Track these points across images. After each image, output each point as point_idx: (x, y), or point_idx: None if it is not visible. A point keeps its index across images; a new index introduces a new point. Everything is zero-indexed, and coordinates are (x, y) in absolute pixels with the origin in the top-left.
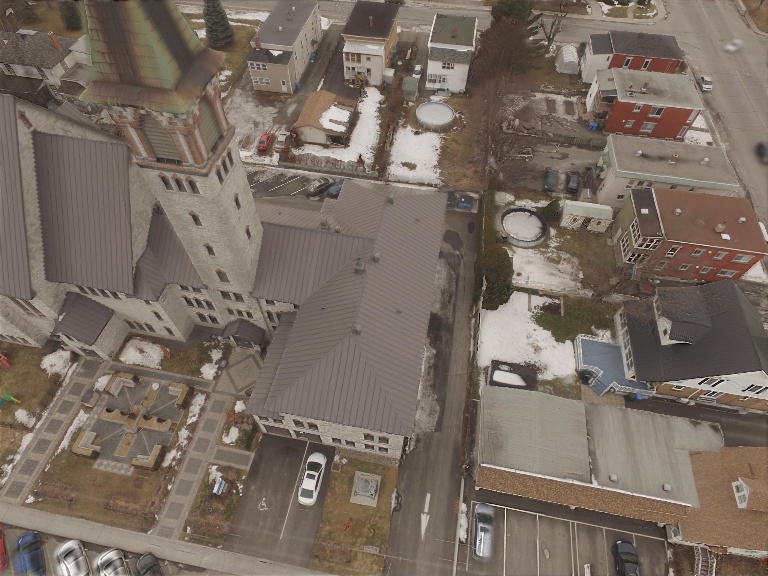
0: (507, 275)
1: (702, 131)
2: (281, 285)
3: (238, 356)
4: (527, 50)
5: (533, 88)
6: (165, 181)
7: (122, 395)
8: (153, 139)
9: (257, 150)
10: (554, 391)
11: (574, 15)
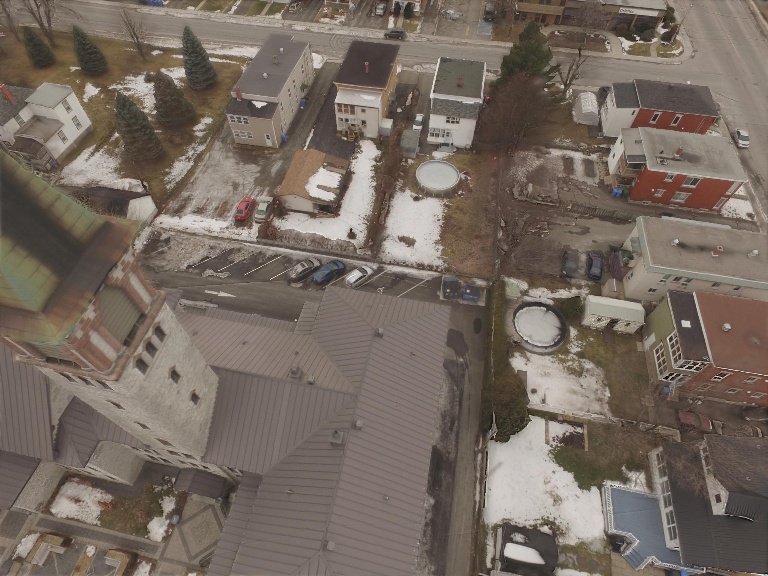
0: (521, 408)
1: (741, 199)
2: (240, 449)
3: (194, 507)
4: (542, 103)
5: (548, 144)
6: (65, 376)
7: (48, 564)
8: (35, 342)
9: (234, 220)
10: (578, 562)
11: (592, 52)
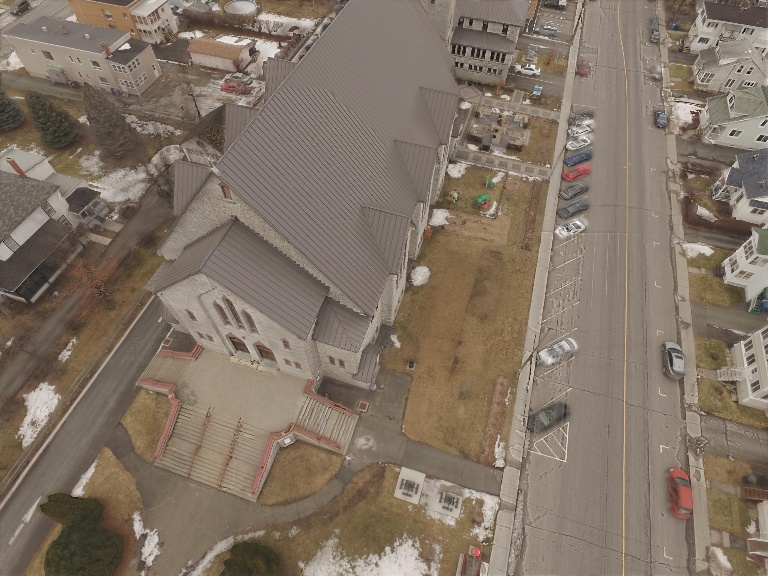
0: None
1: None
2: None
3: None
4: None
5: None
6: None
7: None
8: None
9: (242, 95)
10: None
11: None
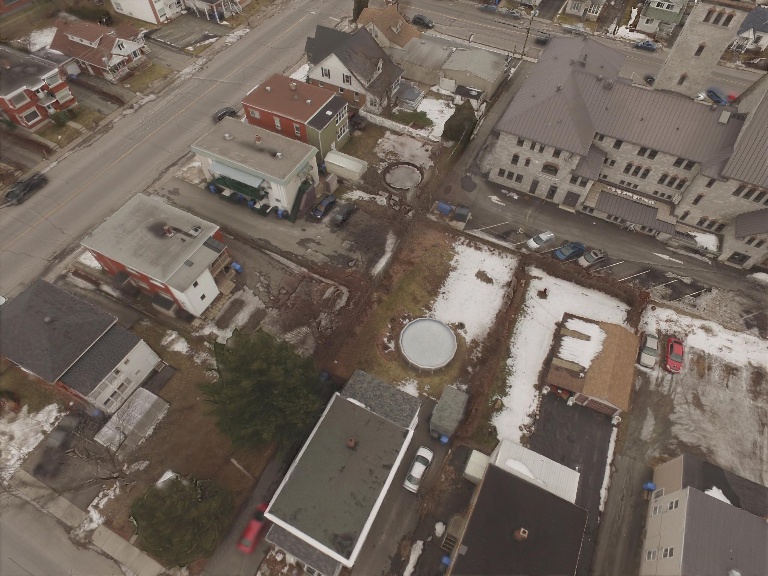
0: None
1: None
2: None
3: None
4: None
5: None
6: None
7: None
8: None
9: None
10: (442, 96)
11: None
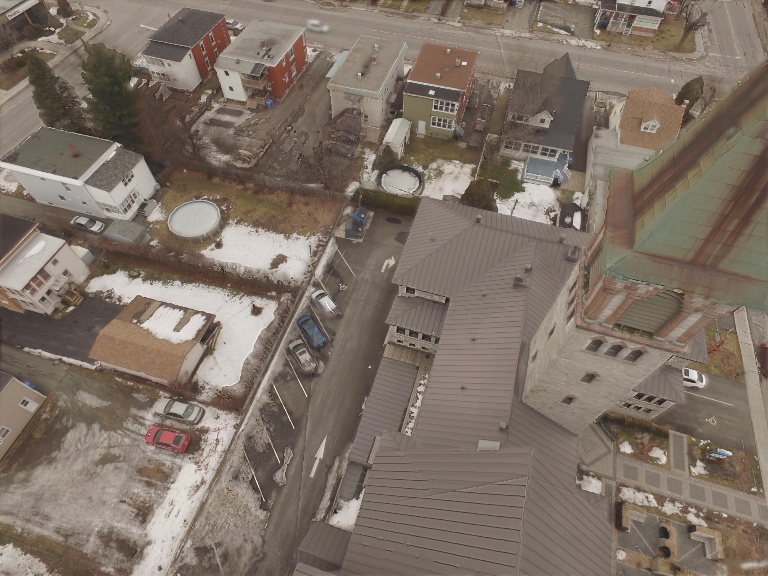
0: None
1: None
2: None
3: None
4: (152, 101)
5: None
6: None
7: None
8: None
9: (183, 454)
10: None
11: None
